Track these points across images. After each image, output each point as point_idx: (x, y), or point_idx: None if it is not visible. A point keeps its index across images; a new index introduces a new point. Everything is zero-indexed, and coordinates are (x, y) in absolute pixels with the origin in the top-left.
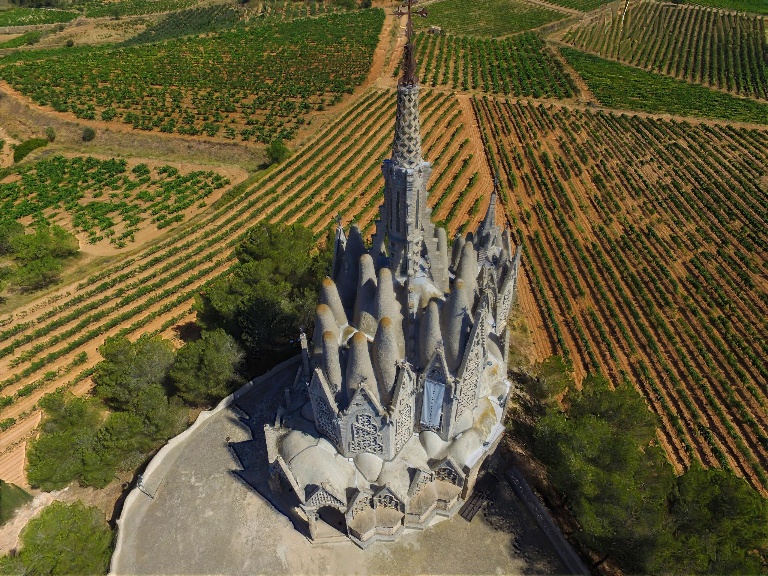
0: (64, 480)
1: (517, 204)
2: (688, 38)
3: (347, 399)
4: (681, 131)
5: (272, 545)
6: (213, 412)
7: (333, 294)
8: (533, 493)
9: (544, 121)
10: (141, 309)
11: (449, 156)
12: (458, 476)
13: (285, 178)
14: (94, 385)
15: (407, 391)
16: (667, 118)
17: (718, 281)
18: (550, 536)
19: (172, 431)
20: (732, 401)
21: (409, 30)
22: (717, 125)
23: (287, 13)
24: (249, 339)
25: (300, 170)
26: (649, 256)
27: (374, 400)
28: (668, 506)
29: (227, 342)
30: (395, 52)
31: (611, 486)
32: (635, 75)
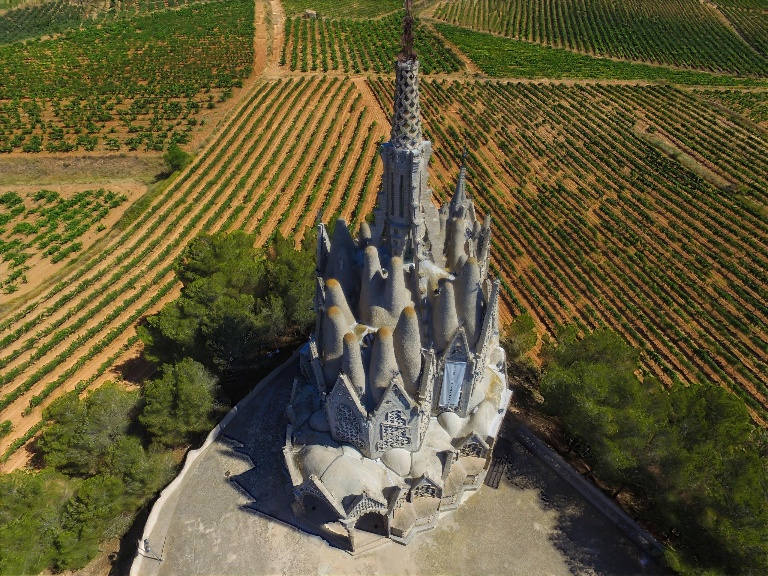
0: (36, 572)
1: (438, 179)
2: (543, 7)
3: (372, 399)
4: (561, 93)
5: (312, 570)
6: (201, 449)
7: (340, 294)
8: (546, 446)
9: (441, 96)
10: (65, 357)
11: (361, 140)
12: (483, 448)
13: (193, 185)
14: (31, 455)
15: (429, 377)
16: (546, 82)
17: (625, 222)
18: (571, 481)
19: (159, 482)
20: (665, 324)
21: (408, 1)
22: (588, 84)
23: (141, 6)
24: (222, 362)
25: (207, 174)
26: (565, 210)
27: (405, 394)
28: (670, 426)
29: (199, 371)
30: (275, 40)
31: (627, 421)
32: (508, 45)
